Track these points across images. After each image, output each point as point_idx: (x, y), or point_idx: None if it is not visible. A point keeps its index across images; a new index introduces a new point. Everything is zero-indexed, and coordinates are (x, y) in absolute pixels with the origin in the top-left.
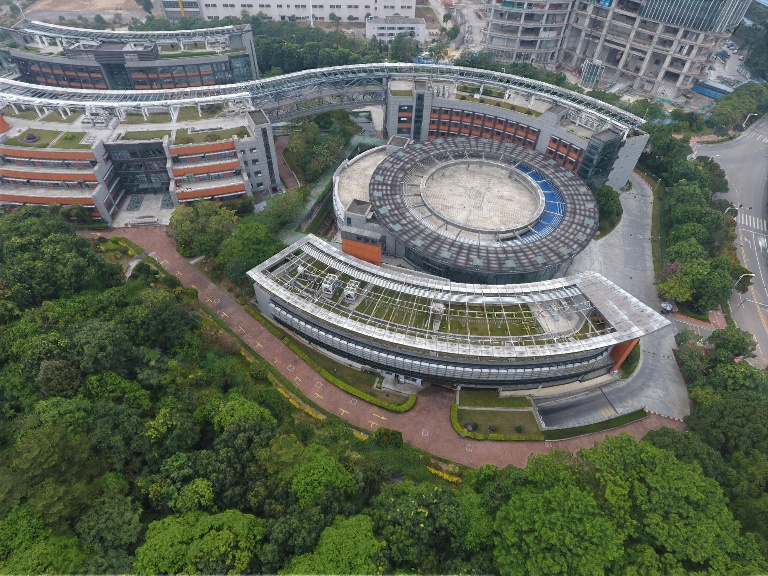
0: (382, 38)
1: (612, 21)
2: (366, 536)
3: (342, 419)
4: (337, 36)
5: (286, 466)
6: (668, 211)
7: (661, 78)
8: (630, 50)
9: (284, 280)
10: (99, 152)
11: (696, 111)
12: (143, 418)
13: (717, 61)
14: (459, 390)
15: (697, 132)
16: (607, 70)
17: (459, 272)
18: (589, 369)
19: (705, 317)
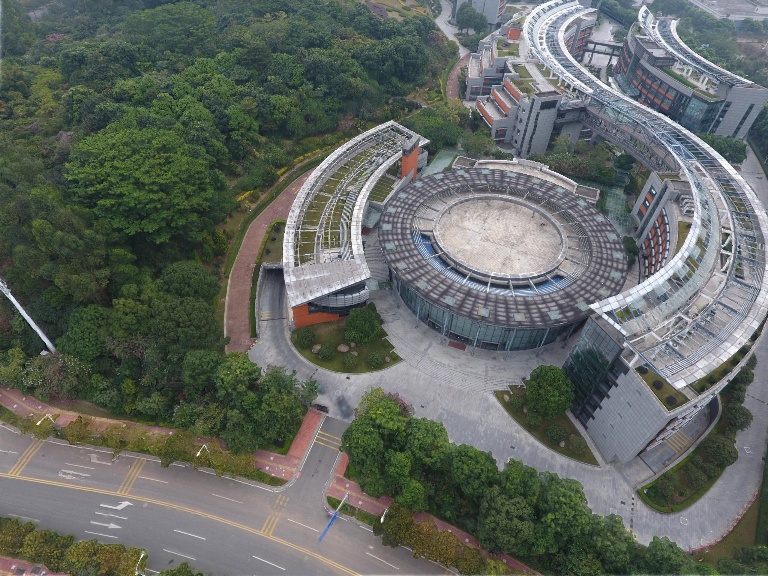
0: None
1: None
2: None
3: None
4: None
5: None
6: None
7: None
8: None
9: None
10: (497, 62)
11: None
12: (289, 88)
13: None
14: None
15: None
16: None
17: None
18: None
19: None
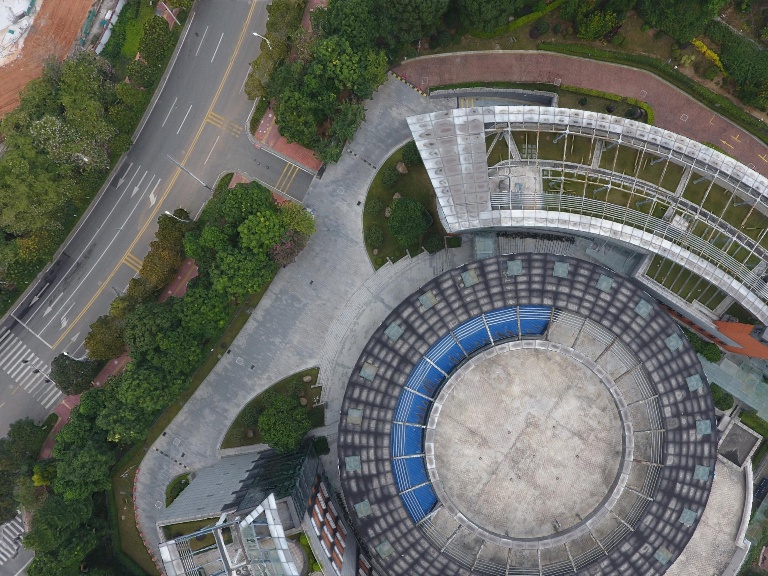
0: None
1: None
2: None
3: None
4: None
5: None
6: None
7: None
8: None
9: None
10: None
11: None
12: None
13: None
14: None
15: None
16: None
17: None
18: None
19: None
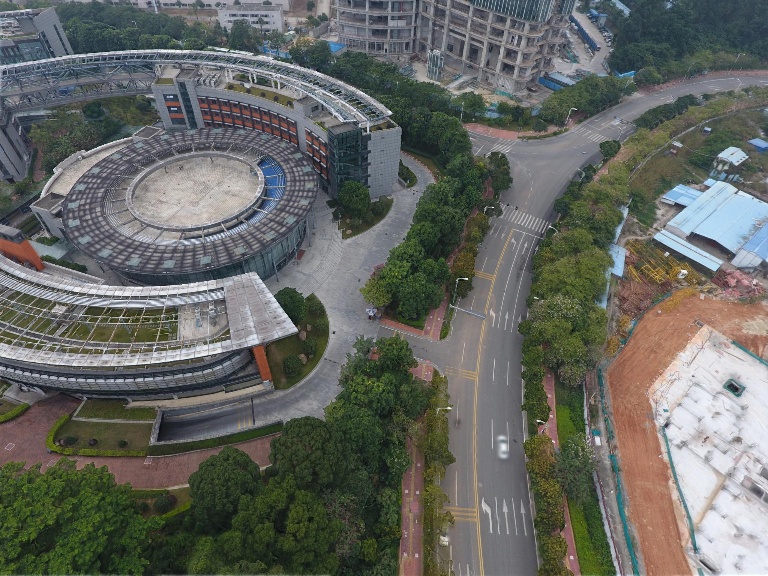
0: None
1: (452, 10)
2: None
3: None
4: (176, 22)
5: None
6: None
7: (499, 70)
8: (471, 40)
9: None
10: None
11: (533, 105)
12: None
13: (587, 54)
14: (86, 400)
15: (524, 127)
16: None
17: None
18: (211, 379)
19: (417, 323)
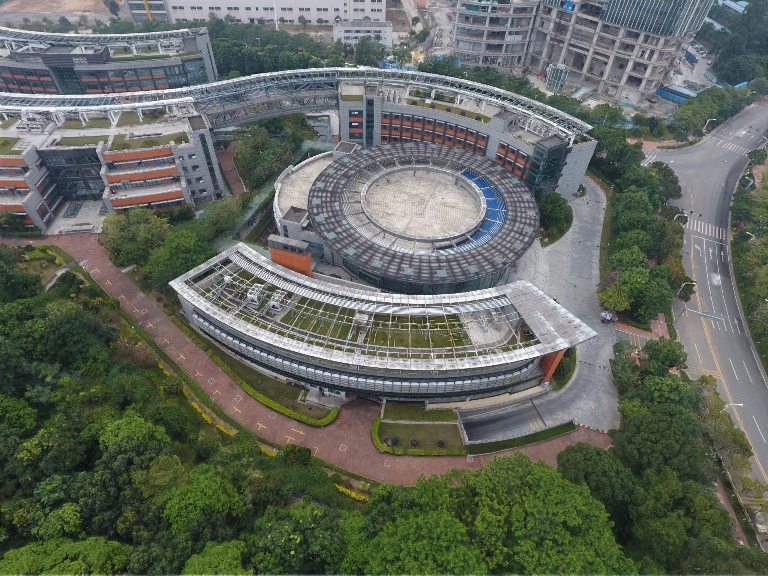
0: (349, 41)
1: (575, 25)
2: (230, 565)
3: (257, 434)
4: (301, 39)
5: (164, 489)
6: (616, 218)
7: (624, 83)
8: (594, 54)
9: (211, 290)
10: (31, 158)
11: (659, 116)
12: (28, 438)
13: (685, 65)
14: (385, 403)
15: (658, 137)
16: (573, 74)
17: (394, 281)
18: (515, 381)
19: (646, 326)
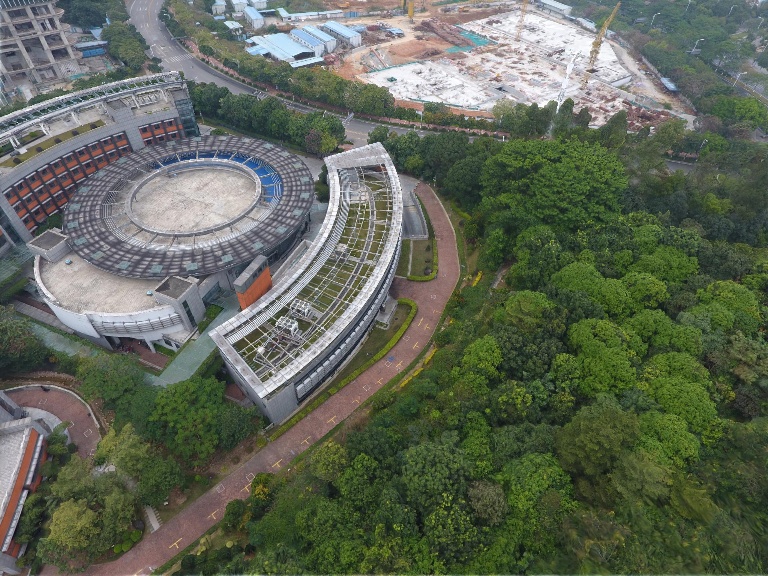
0: None
1: None
2: None
3: None
4: None
5: (530, 314)
6: (247, 120)
7: (54, 59)
8: None
9: None
10: None
11: (108, 69)
12: None
13: None
14: None
15: None
16: None
17: None
18: None
19: (341, 149)
